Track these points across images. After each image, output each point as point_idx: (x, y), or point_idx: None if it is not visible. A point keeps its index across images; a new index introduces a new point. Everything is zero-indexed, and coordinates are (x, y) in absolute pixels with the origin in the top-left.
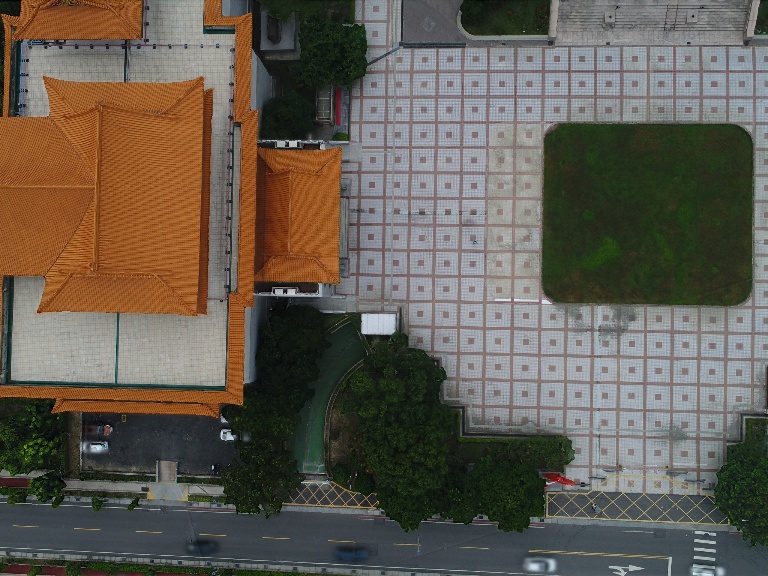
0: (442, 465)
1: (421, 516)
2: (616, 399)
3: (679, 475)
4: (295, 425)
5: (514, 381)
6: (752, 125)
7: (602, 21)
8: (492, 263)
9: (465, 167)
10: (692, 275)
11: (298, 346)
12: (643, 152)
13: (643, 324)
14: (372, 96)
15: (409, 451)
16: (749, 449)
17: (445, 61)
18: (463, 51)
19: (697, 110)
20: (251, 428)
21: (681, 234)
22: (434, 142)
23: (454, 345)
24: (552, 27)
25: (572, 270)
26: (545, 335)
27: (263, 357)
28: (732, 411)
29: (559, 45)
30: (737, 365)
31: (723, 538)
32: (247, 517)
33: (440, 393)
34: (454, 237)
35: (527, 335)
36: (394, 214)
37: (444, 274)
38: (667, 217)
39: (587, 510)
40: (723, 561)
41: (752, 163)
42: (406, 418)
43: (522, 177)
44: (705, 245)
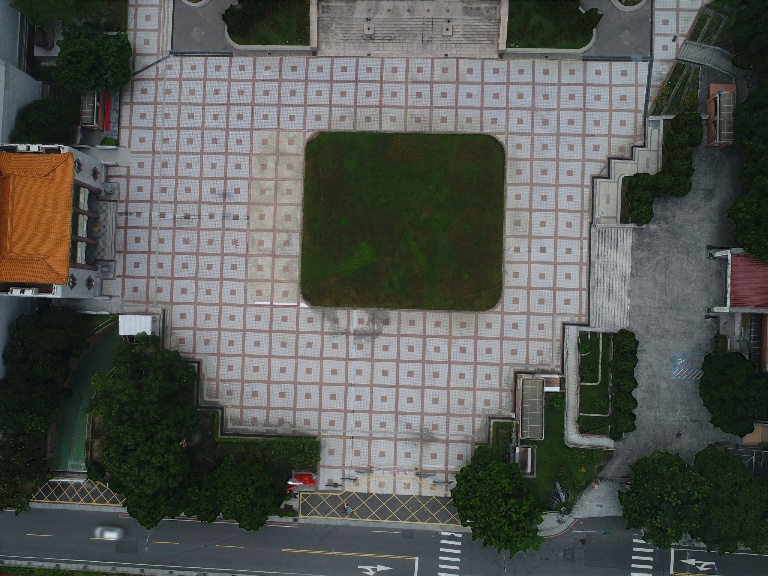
0: (172, 464)
1: (158, 514)
2: (369, 401)
3: (428, 477)
4: (63, 424)
5: (271, 383)
6: (505, 135)
7: (362, 33)
8: (253, 267)
9: (229, 173)
10: (444, 281)
11: (42, 345)
12: (399, 160)
13: (397, 328)
14: (142, 102)
15: (136, 449)
16: (487, 452)
17: (213, 69)
18: (230, 60)
19: (452, 120)
20: (2, 426)
21: (434, 241)
22: (200, 148)
23: (215, 347)
24: (313, 38)
25: (329, 275)
26: (302, 338)
27: (8, 356)
28: (480, 414)
29: (322, 55)
30: (486, 369)
31: (468, 539)
32: (13, 514)
33: (200, 394)
34: (217, 241)
35: (285, 338)
36: (160, 218)
37: (207, 277)
38: (421, 224)
39: (339, 510)
40: (467, 562)
41: (504, 172)
42: (137, 417)
43: (283, 183)
44: (457, 252)
